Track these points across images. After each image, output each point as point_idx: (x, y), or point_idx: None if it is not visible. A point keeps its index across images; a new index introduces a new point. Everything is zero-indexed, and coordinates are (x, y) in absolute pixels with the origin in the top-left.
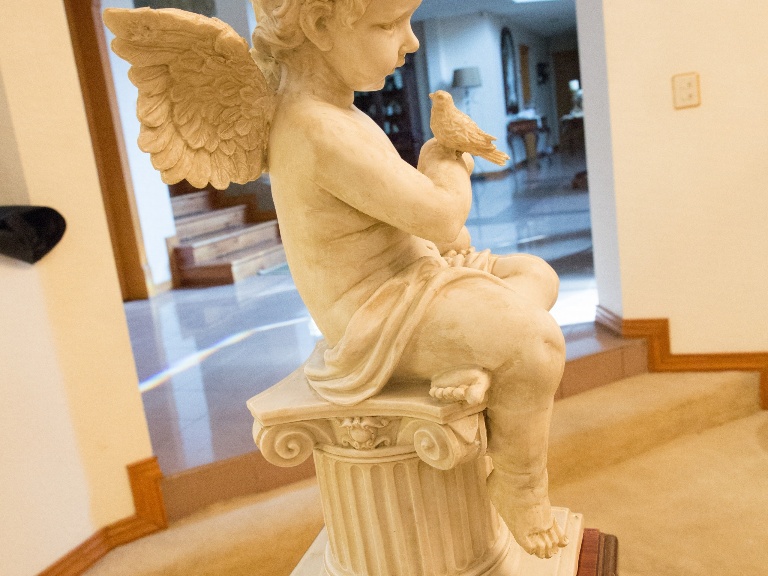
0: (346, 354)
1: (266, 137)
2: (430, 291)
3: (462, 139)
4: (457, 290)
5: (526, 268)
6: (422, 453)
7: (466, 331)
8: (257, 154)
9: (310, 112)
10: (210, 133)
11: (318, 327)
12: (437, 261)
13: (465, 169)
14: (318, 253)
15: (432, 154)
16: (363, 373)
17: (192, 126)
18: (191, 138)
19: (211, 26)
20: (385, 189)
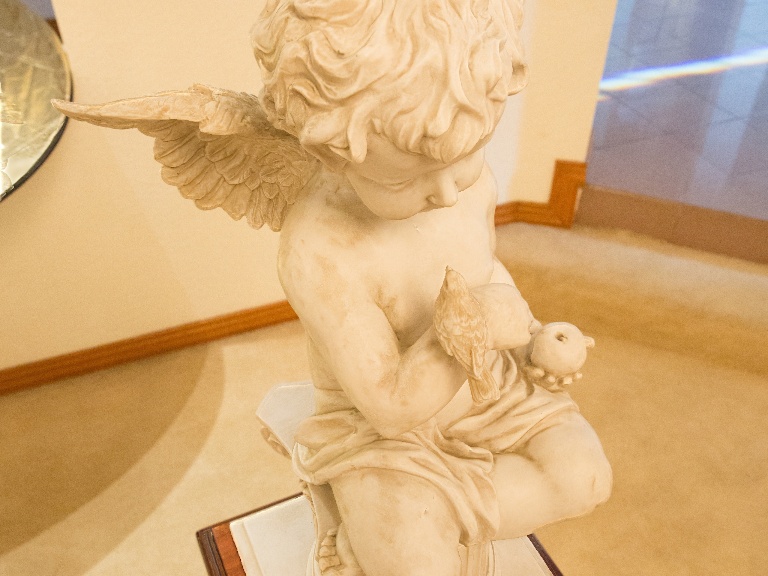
0: None
1: None
2: (348, 464)
3: (444, 347)
4: (375, 481)
5: (552, 471)
6: None
7: (350, 526)
8: None
9: (295, 229)
10: (254, 170)
11: None
12: None
13: (455, 369)
14: (307, 340)
15: None
16: None
17: (232, 161)
18: (228, 173)
19: None
20: (328, 354)
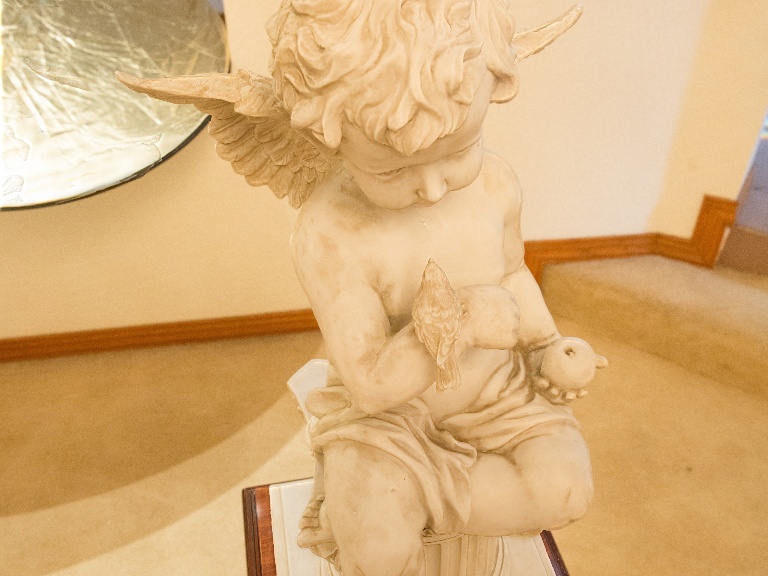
0: None
1: None
2: (334, 433)
3: (417, 334)
4: (354, 453)
5: (529, 477)
6: None
7: (327, 491)
8: None
9: (309, 208)
10: (297, 154)
11: None
12: (409, 403)
13: (430, 358)
14: None
15: None
16: None
17: (278, 144)
18: (274, 154)
19: None
20: (322, 327)
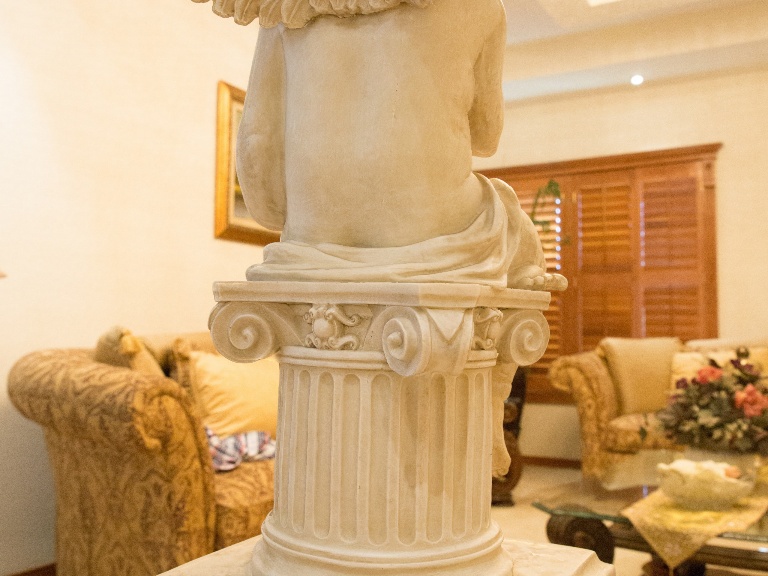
0: None
1: None
2: None
3: None
4: None
5: None
6: (514, 351)
7: None
8: None
9: None
10: None
11: (427, 210)
12: None
13: None
14: (462, 119)
15: None
16: (505, 255)
17: None
18: None
19: None
20: None
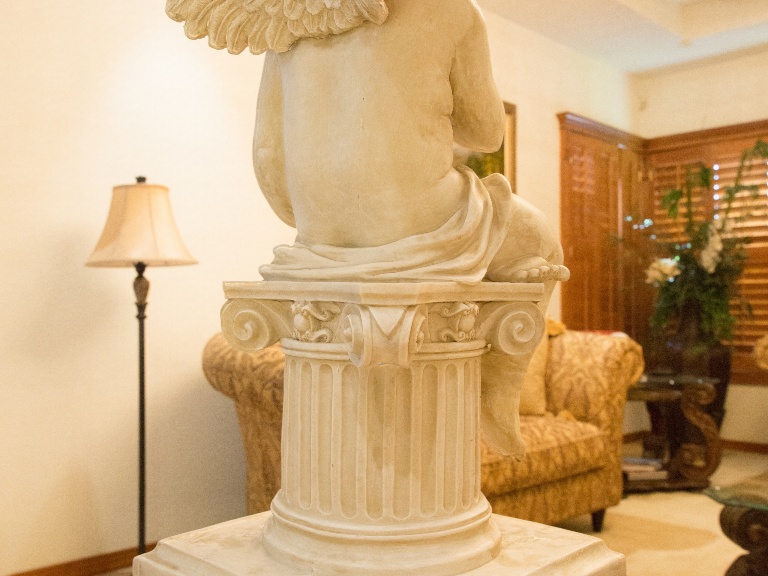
0: (474, 228)
1: None
2: None
3: None
4: None
5: None
6: (504, 342)
7: (537, 221)
8: None
9: None
10: None
11: (398, 211)
12: None
13: None
14: (433, 123)
15: None
16: (482, 251)
17: None
18: None
19: None
20: (492, 80)
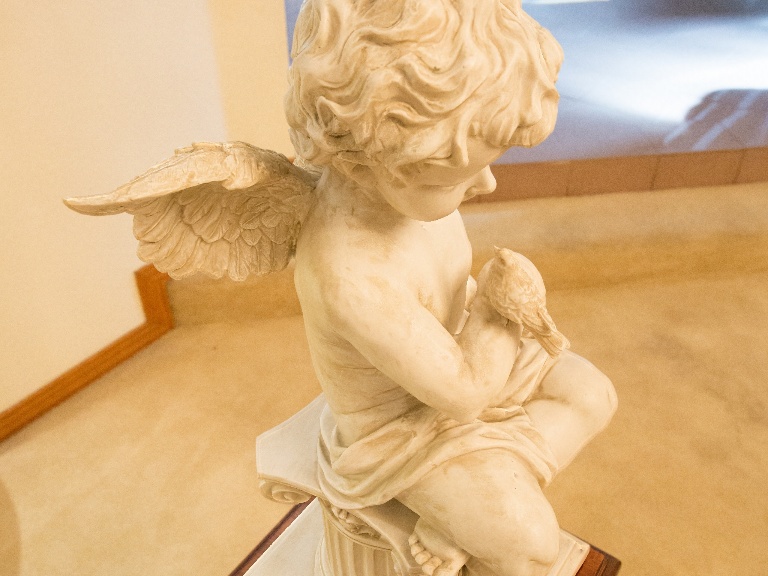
0: (339, 472)
1: (296, 234)
2: (429, 465)
3: (513, 319)
4: (460, 469)
5: (577, 400)
6: None
7: (452, 520)
8: (283, 250)
9: (333, 260)
10: (232, 221)
11: None
12: None
13: (514, 337)
14: (330, 370)
15: (482, 305)
16: (352, 492)
17: (209, 218)
18: (206, 232)
19: (210, 181)
20: (399, 367)
